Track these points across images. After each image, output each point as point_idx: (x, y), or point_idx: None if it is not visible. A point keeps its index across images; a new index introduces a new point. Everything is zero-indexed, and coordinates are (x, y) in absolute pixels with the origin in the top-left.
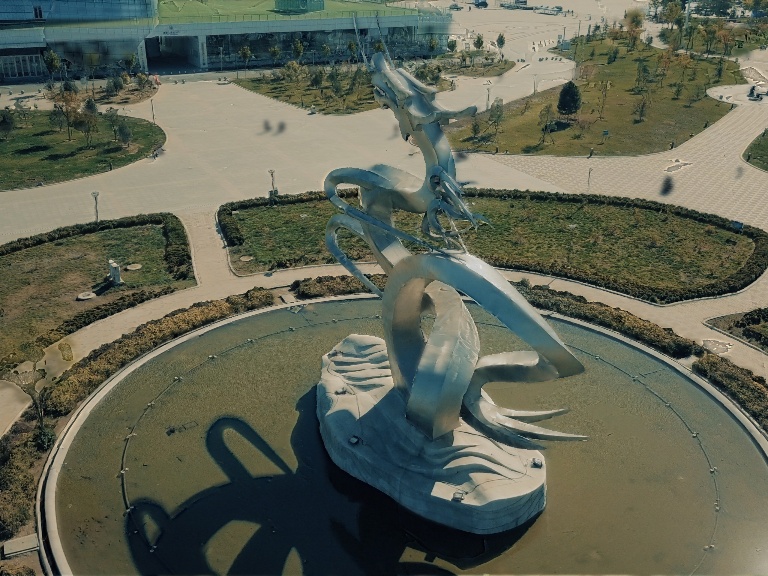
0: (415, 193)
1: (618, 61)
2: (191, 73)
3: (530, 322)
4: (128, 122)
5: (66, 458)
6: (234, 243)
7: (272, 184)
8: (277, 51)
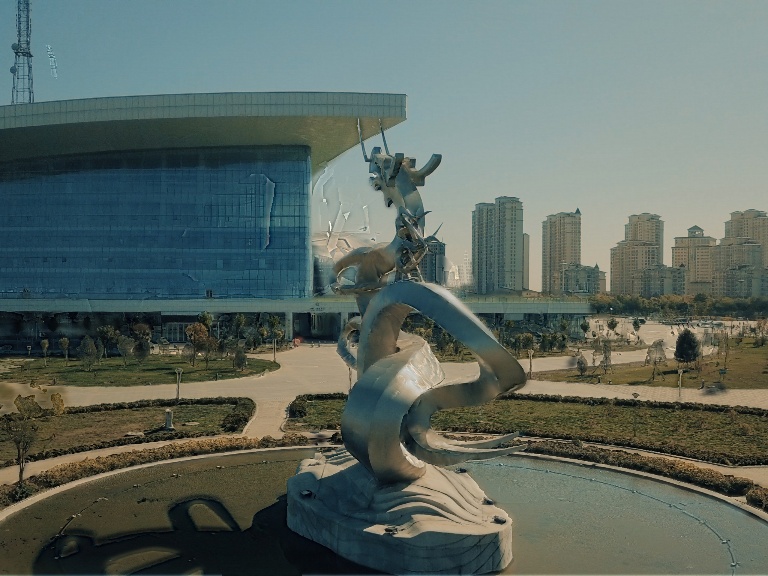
0: (388, 245)
1: (766, 346)
2: (330, 343)
3: (463, 319)
4: (252, 361)
5: (30, 506)
6: (295, 415)
7: None
8: (409, 322)
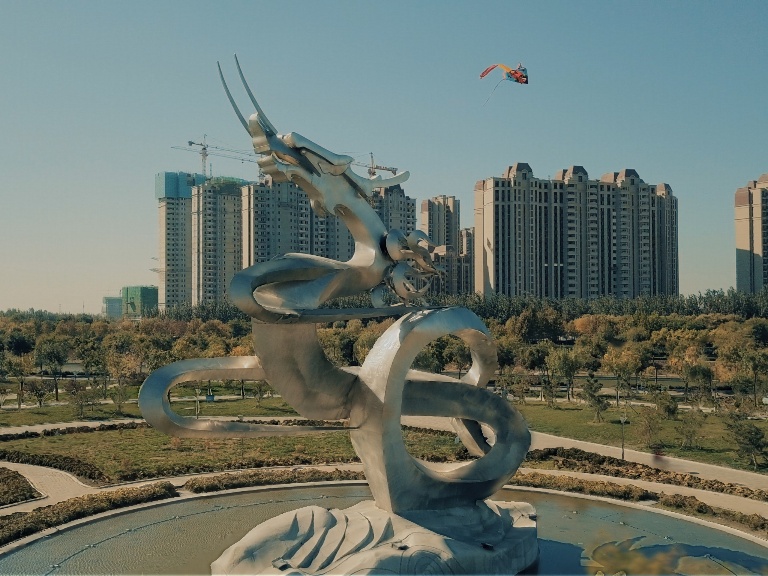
0: (374, 265)
1: None
2: None
3: None
4: None
5: None
6: None
7: None
8: None
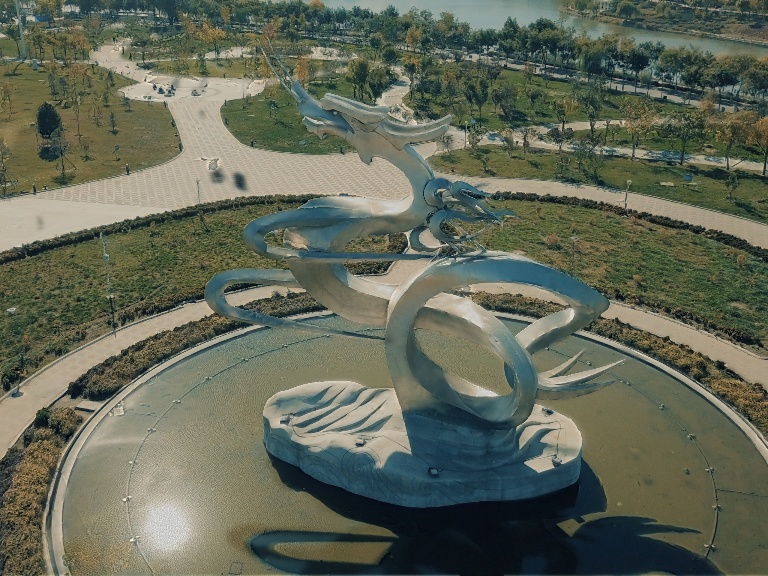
0: (406, 212)
1: None
2: None
3: (582, 285)
4: None
5: None
6: None
7: None
8: None
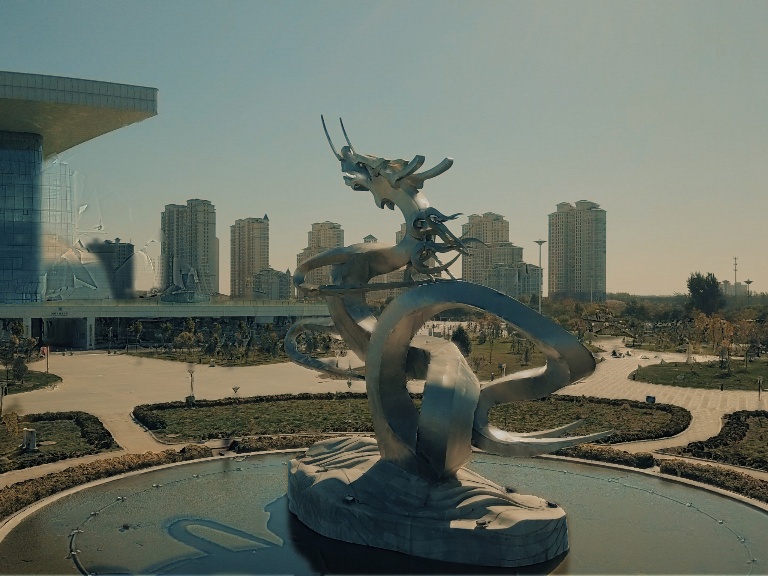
0: (396, 246)
1: (488, 343)
2: (78, 351)
3: (537, 317)
4: None
5: None
6: (157, 427)
7: (191, 385)
8: (169, 326)
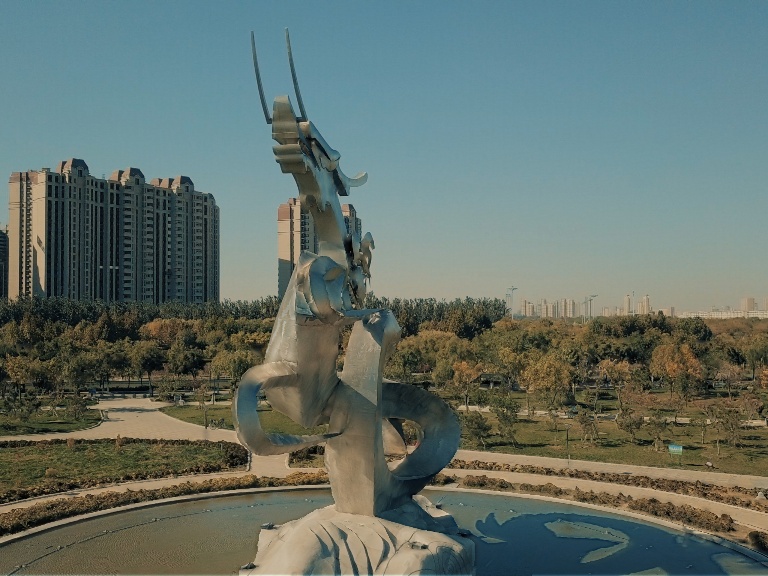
0: None
1: None
2: None
3: None
4: None
5: None
6: None
7: None
8: None
